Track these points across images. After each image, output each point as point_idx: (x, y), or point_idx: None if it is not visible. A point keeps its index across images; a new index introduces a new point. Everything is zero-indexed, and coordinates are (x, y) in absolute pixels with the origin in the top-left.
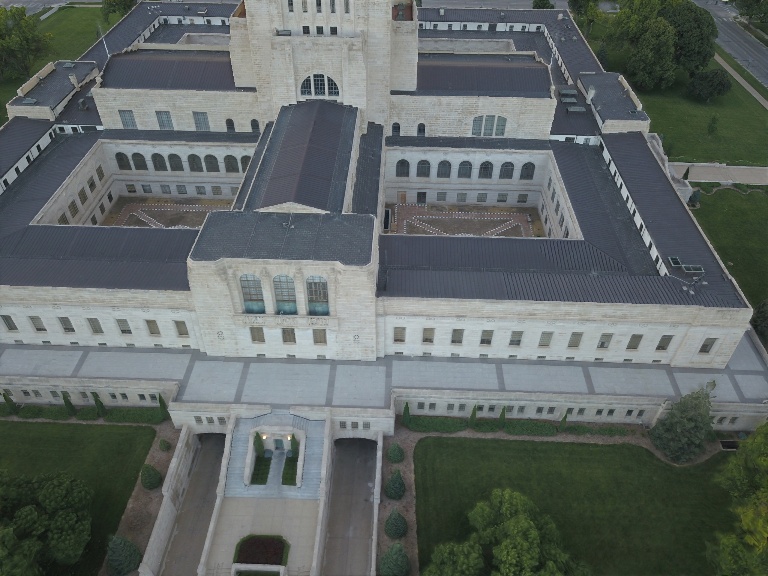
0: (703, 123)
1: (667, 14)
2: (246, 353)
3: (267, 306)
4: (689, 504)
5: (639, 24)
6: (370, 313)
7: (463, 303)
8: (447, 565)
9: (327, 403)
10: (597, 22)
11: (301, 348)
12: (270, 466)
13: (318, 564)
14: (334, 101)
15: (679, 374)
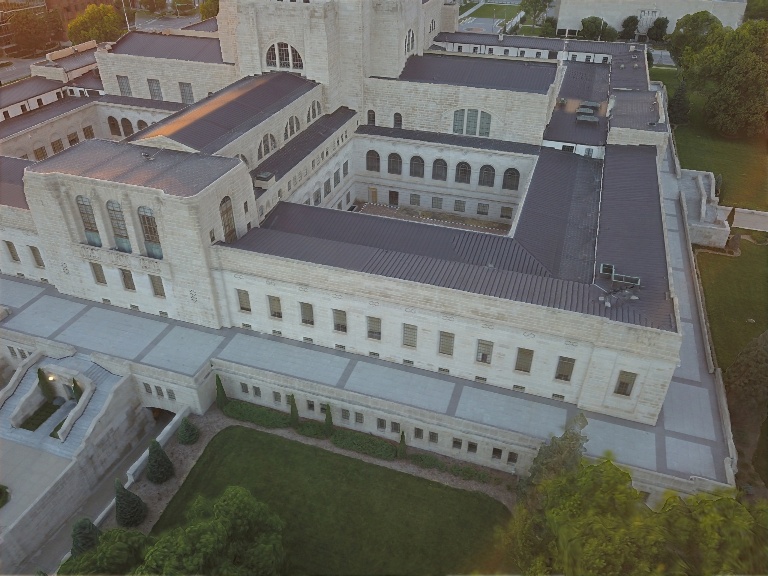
0: None
1: (764, 52)
2: (92, 296)
3: (102, 238)
4: None
5: (726, 60)
6: (201, 262)
7: (302, 266)
8: None
9: (136, 358)
10: (692, 67)
11: (142, 298)
12: (52, 414)
13: (29, 531)
14: (298, 74)
15: None
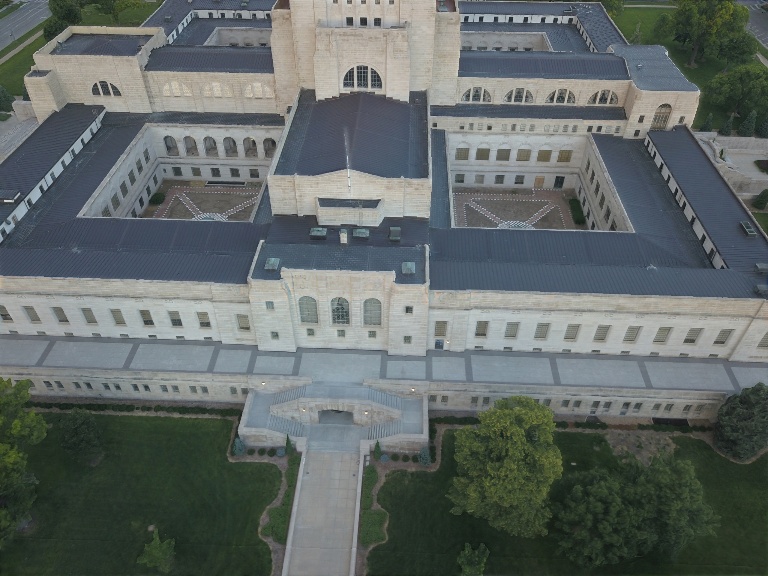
0: None
1: None
2: None
3: None
4: None
5: None
6: None
7: None
8: (759, 95)
9: None
10: None
11: None
12: None
13: None
14: None
15: None
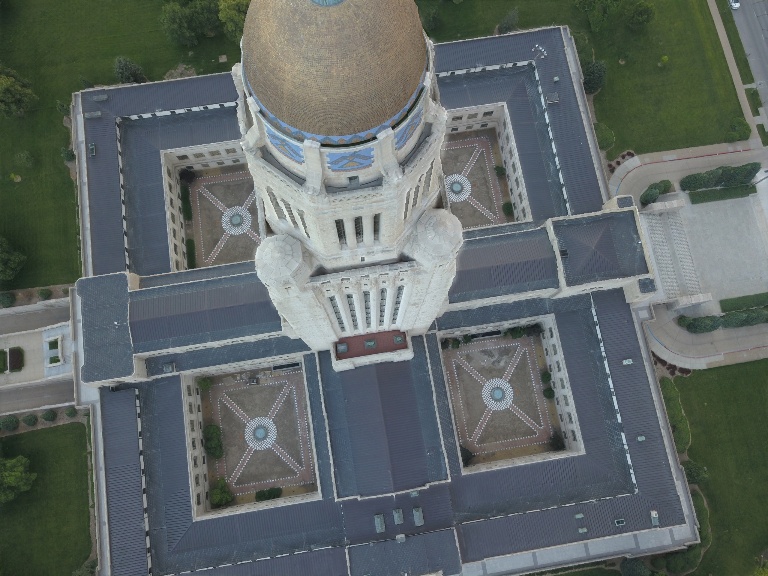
0: None
1: None
2: None
3: None
4: (58, 575)
5: None
6: None
7: None
8: None
9: None
10: (758, 572)
11: None
12: None
13: None
14: None
15: None
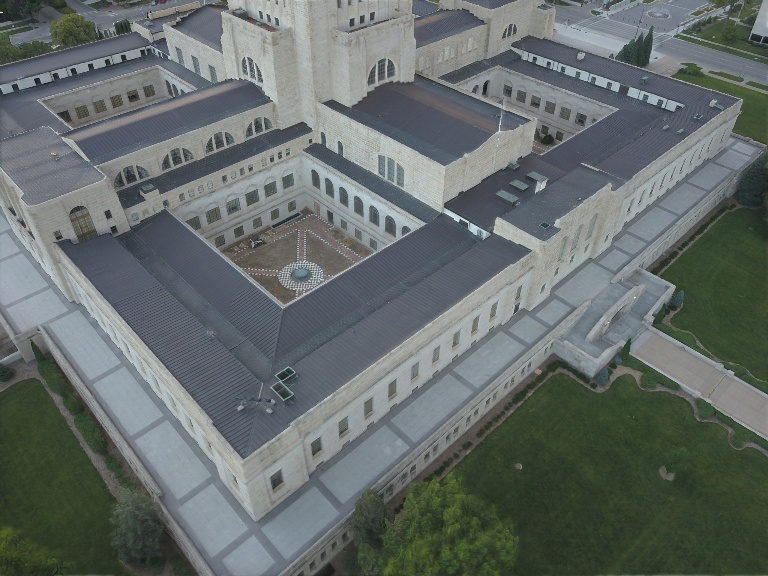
0: None
1: None
2: (25, 245)
3: None
4: None
5: None
6: None
7: (86, 283)
8: None
9: (6, 306)
10: None
11: None
12: None
13: None
14: (260, 88)
15: (214, 488)
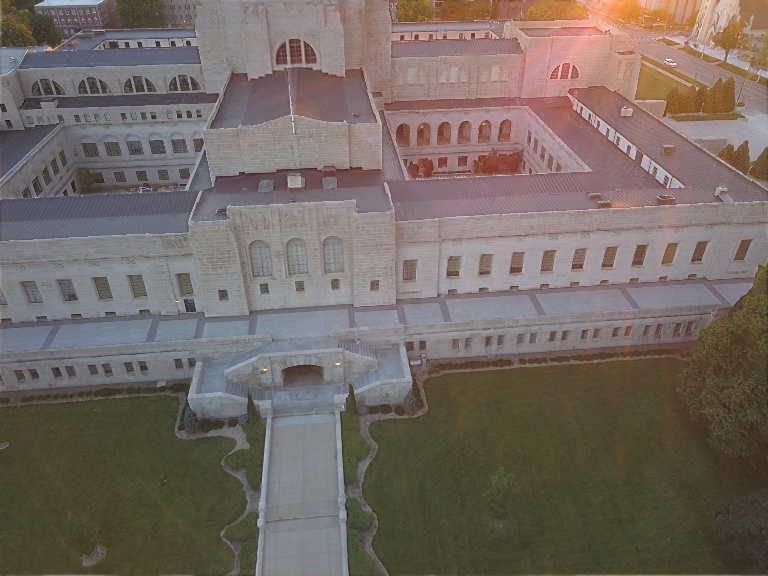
0: (582, 528)
1: None
2: None
3: None
4: None
5: None
6: None
7: None
8: None
9: None
10: None
11: None
12: None
13: None
14: None
15: None
